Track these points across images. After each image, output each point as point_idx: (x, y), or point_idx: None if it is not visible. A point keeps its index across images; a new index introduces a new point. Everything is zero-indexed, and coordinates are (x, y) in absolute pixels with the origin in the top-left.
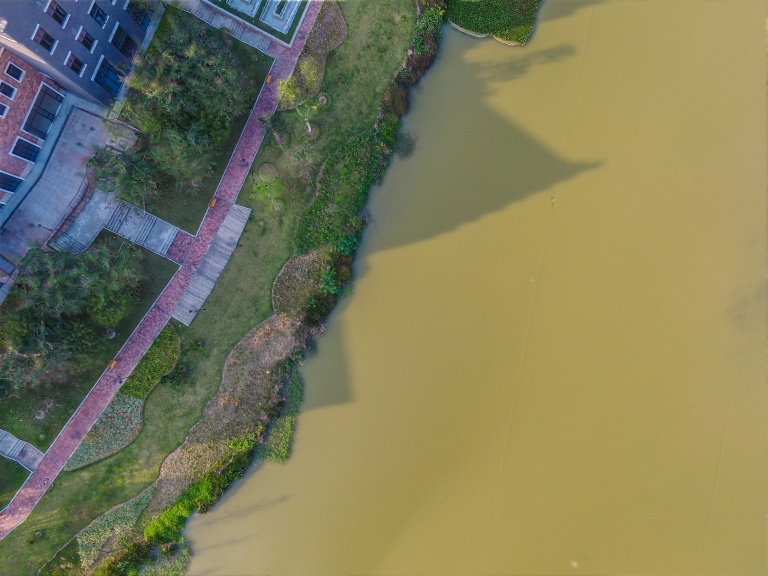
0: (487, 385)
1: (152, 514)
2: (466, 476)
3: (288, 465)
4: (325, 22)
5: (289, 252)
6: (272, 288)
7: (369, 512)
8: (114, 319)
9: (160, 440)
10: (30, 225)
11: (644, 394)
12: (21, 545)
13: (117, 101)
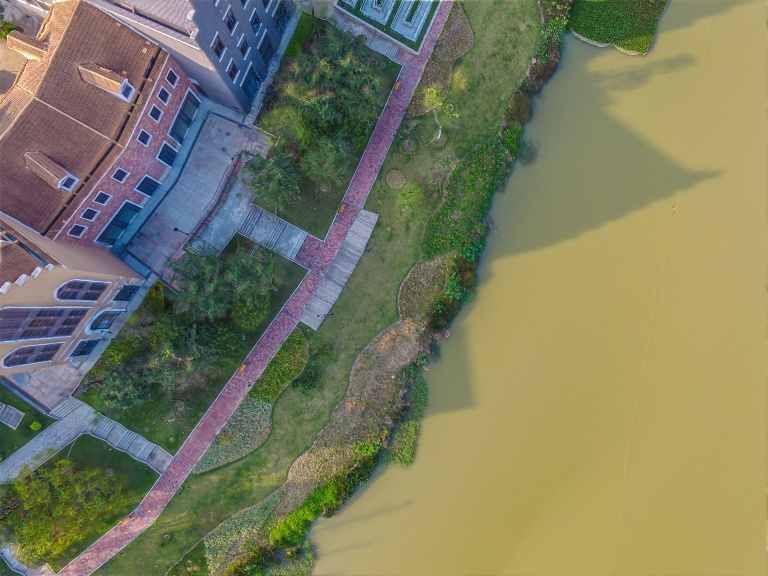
0: (609, 392)
1: (278, 518)
2: (589, 482)
3: (412, 470)
4: (452, 30)
5: (415, 258)
6: (398, 293)
7: (492, 518)
8: (256, 323)
9: (288, 444)
10: (166, 229)
11: (765, 402)
12: (150, 548)
13: (253, 107)
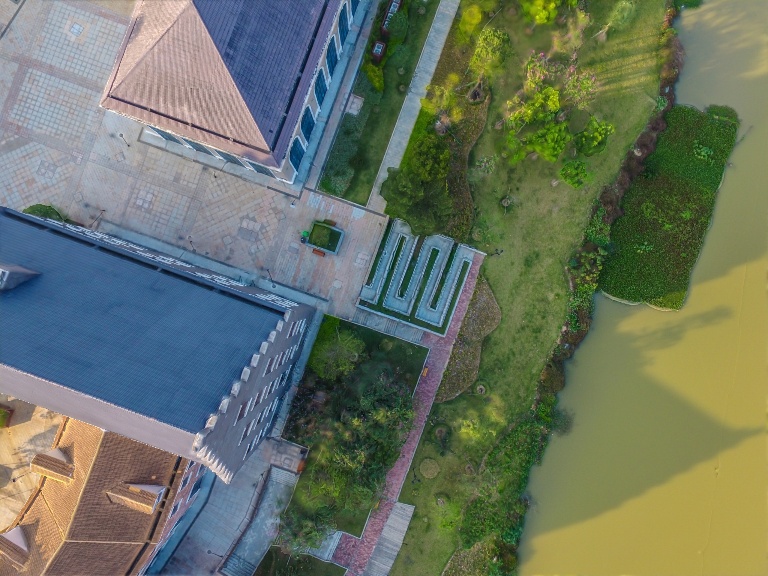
0: None
1: None
2: None
3: None
4: (478, 307)
5: (454, 545)
6: None
7: None
8: None
9: None
10: (200, 552)
11: None
12: None
13: (279, 418)
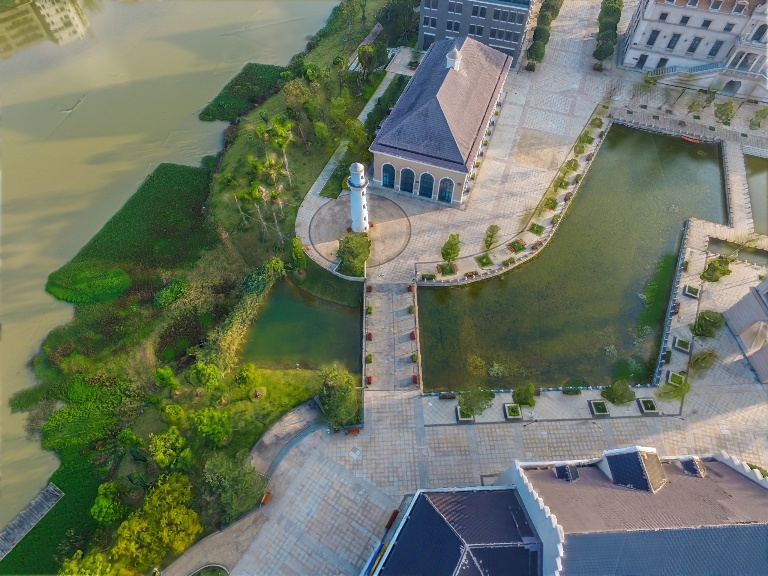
0: None
1: None
2: None
3: None
4: None
5: None
6: None
7: None
8: None
9: None
10: None
11: None
12: None
13: None
